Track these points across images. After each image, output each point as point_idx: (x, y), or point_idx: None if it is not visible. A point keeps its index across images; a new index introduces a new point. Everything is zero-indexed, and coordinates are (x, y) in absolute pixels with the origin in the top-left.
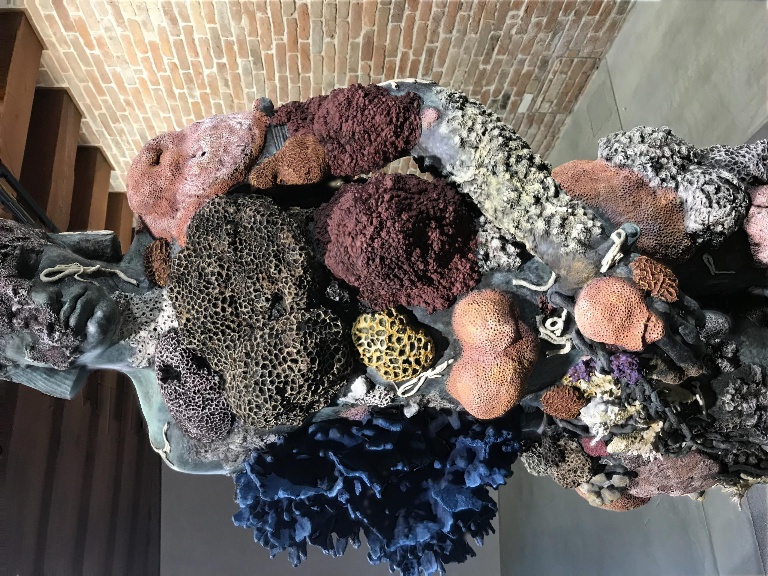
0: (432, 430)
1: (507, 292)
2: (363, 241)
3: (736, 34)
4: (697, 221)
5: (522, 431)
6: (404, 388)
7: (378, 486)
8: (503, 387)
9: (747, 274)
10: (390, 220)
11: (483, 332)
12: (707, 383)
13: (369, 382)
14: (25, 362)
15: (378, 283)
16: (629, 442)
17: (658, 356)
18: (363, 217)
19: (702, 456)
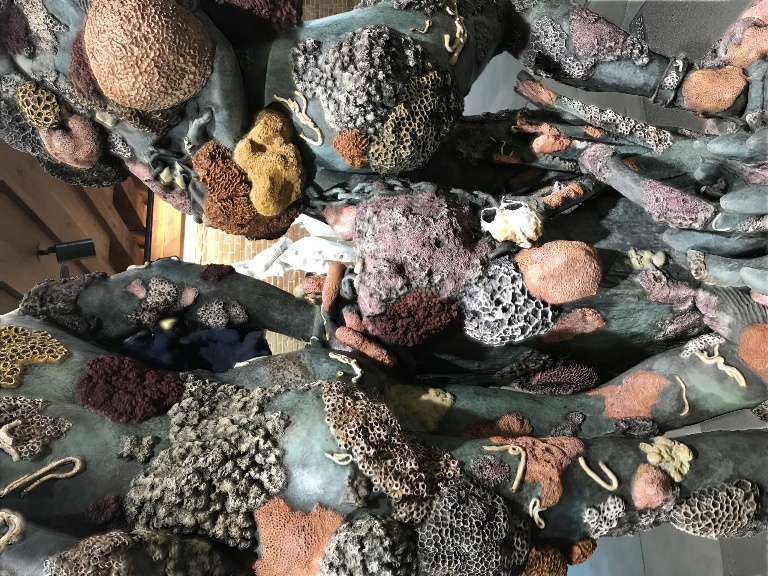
0: (203, 355)
1: None
2: None
3: None
4: None
5: None
6: None
7: None
8: None
9: None
10: None
11: None
12: None
13: None
14: None
15: None
16: None
17: None
18: None
19: None
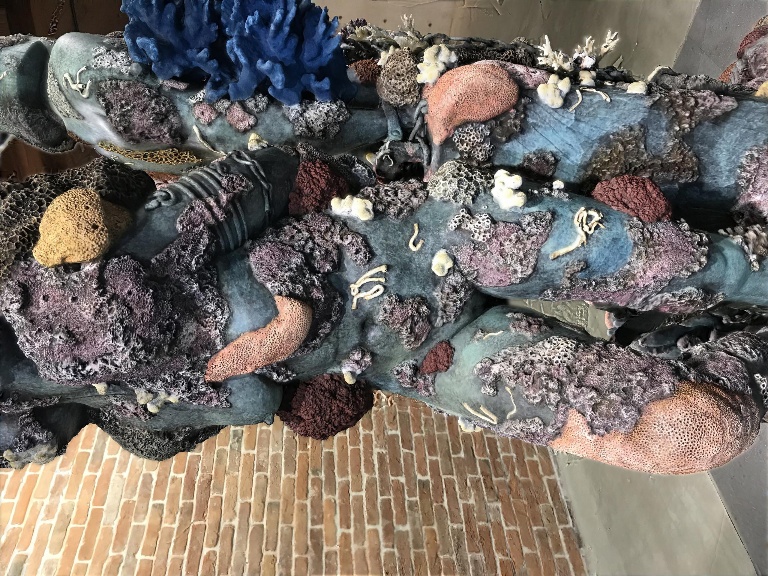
0: None
1: None
2: None
3: None
4: None
5: None
6: None
7: None
8: None
9: None
10: None
11: None
12: None
13: None
14: None
15: None
16: None
17: None
18: None
19: None
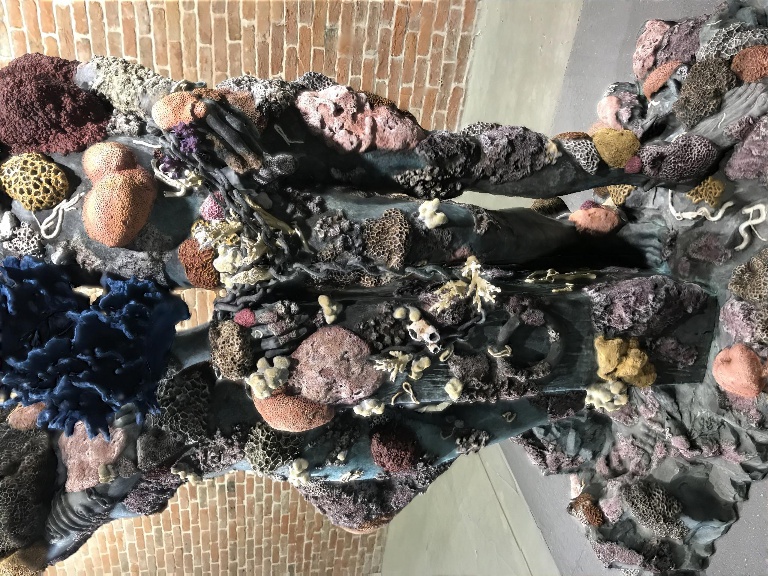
0: None
1: (128, 146)
2: (5, 90)
3: None
4: (259, 97)
5: (237, 416)
6: (46, 225)
7: (6, 289)
8: (114, 191)
9: (316, 147)
10: (28, 80)
11: (99, 155)
12: (303, 221)
13: (14, 218)
14: None
15: (18, 124)
16: (248, 272)
17: (212, 134)
18: (8, 79)
19: (347, 331)
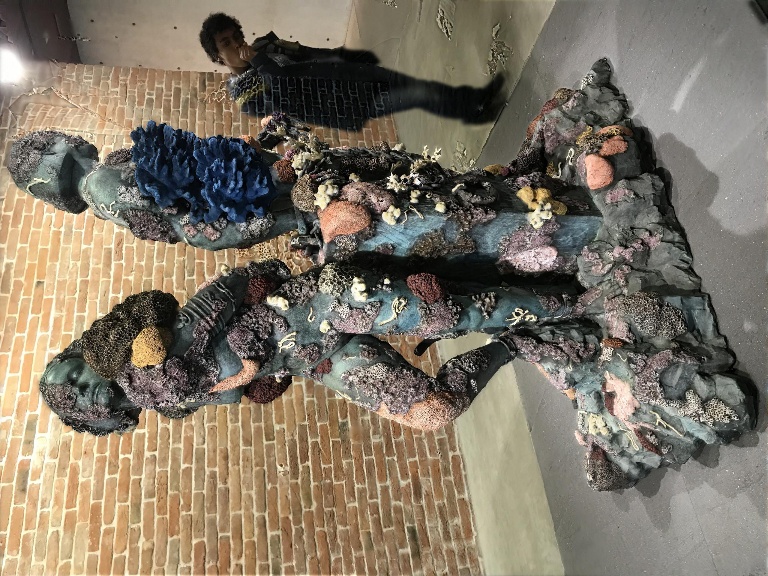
0: None
1: None
2: None
3: (536, 549)
4: None
5: None
6: None
7: None
8: None
9: None
10: None
11: None
12: None
13: None
14: (59, 144)
15: None
16: None
17: None
18: None
19: None
